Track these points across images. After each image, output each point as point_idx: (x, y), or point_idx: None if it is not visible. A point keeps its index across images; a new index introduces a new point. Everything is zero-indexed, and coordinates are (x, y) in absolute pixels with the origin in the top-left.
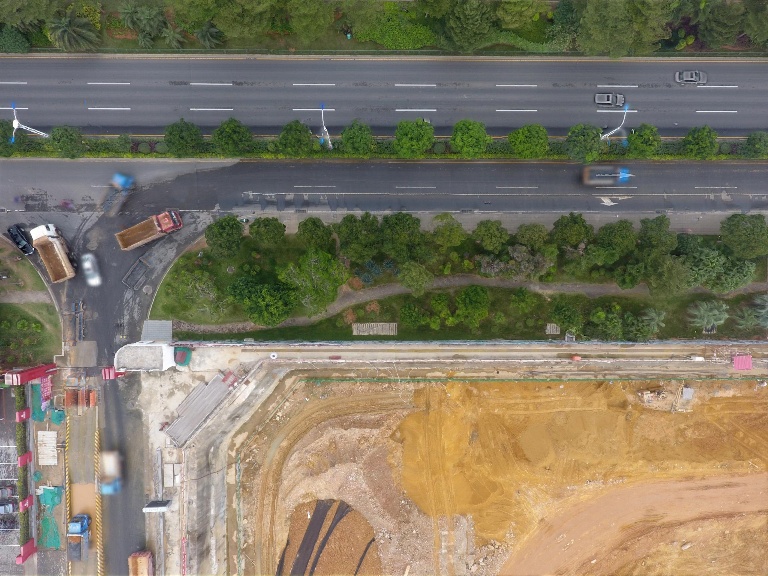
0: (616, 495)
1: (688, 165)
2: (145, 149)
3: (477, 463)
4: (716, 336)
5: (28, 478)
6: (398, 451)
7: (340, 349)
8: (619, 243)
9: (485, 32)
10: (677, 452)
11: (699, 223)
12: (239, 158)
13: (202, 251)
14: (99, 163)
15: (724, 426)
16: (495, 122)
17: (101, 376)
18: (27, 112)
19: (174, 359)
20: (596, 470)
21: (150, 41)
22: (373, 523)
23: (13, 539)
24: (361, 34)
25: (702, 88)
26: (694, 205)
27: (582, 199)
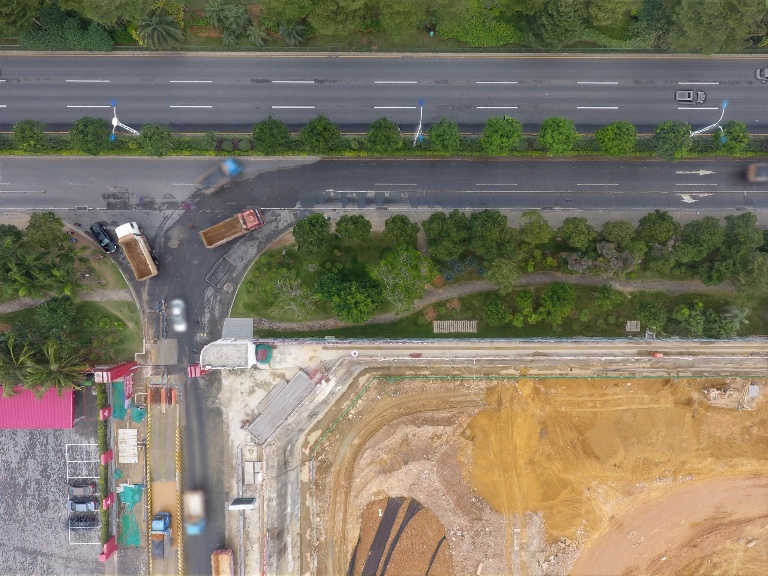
0: (685, 492)
1: None
2: (228, 147)
3: (547, 461)
4: None
5: (108, 476)
6: (469, 449)
7: (421, 347)
8: (707, 240)
9: (577, 29)
10: (744, 449)
11: None
12: (321, 156)
13: (283, 249)
14: (181, 161)
15: None
16: (576, 119)
17: (182, 374)
18: (109, 110)
19: (255, 357)
20: (665, 467)
21: (234, 39)
22: (444, 521)
23: (93, 537)
24: (444, 31)
25: None
26: None
27: (662, 196)
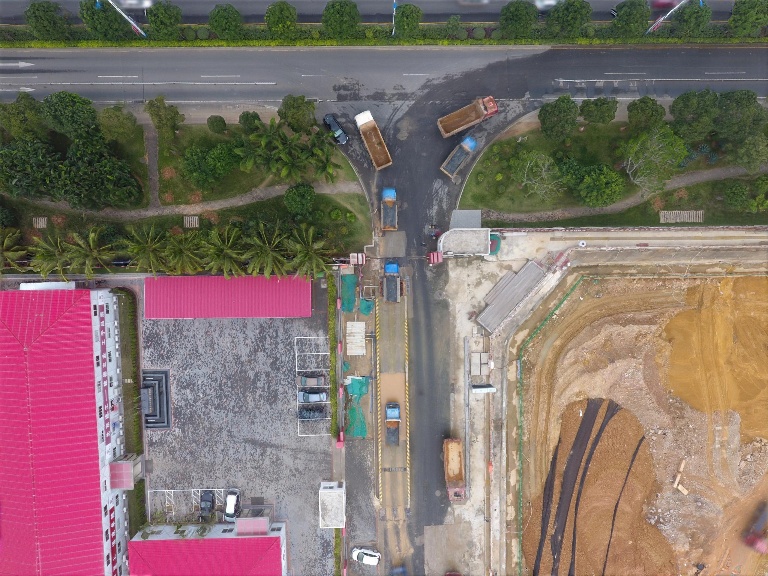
0: None
1: None
2: (464, 34)
3: (744, 361)
4: None
5: (336, 368)
6: (667, 350)
7: (647, 237)
8: None
9: None
10: None
11: None
12: (551, 45)
13: (513, 139)
14: (411, 51)
15: None
16: None
17: (410, 266)
18: None
19: None
20: None
21: None
22: (644, 420)
23: (321, 428)
24: None
25: None
26: None
27: None
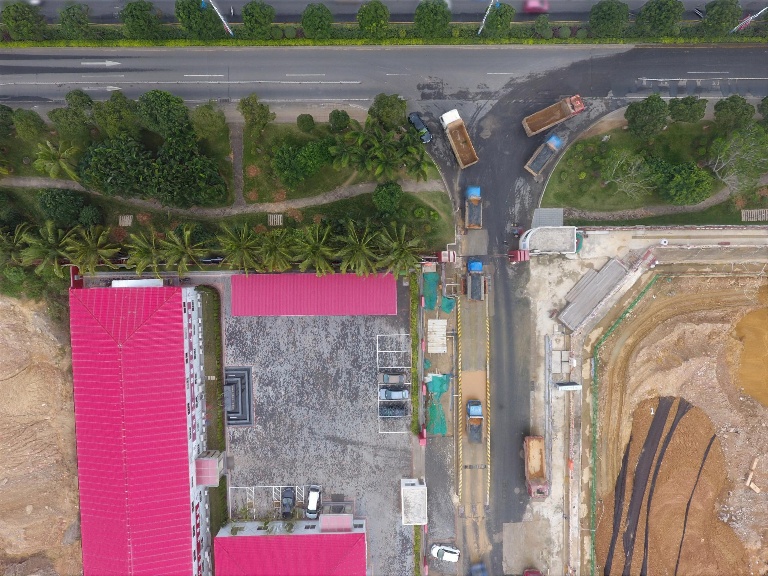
0: None
1: None
2: (549, 33)
3: None
4: None
5: (417, 366)
6: (738, 348)
7: (729, 235)
8: None
9: None
10: None
11: None
12: (635, 44)
13: (596, 138)
14: (495, 50)
15: None
16: None
17: (491, 264)
18: None
19: None
20: None
21: None
22: (715, 419)
23: (402, 426)
24: None
25: None
26: None
27: None
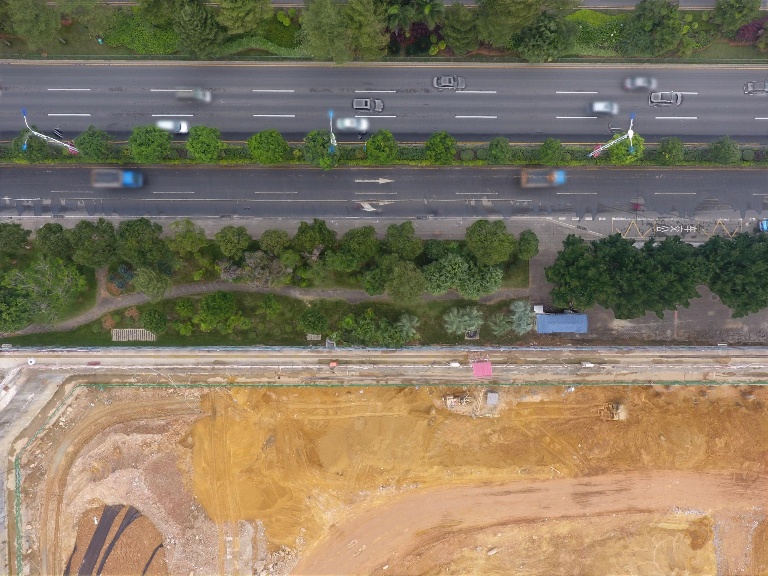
0: (410, 501)
1: (448, 171)
2: None
3: (267, 468)
4: (479, 342)
5: None
6: (187, 456)
7: (99, 355)
8: (357, 249)
9: (210, 38)
10: (478, 457)
11: (460, 229)
12: None
13: None
14: None
15: (532, 431)
16: (253, 127)
17: None
18: None
19: None
20: (390, 475)
21: None
22: (161, 529)
23: None
24: (111, 39)
25: (461, 93)
26: (455, 211)
27: (342, 205)
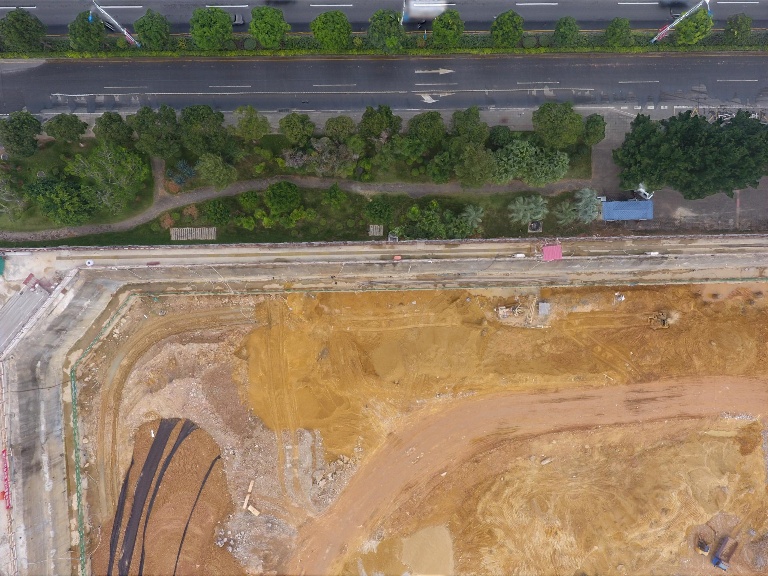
0: (466, 408)
1: (509, 60)
2: None
3: (324, 378)
4: (542, 235)
5: None
6: (243, 368)
7: (158, 255)
8: (424, 133)
9: None
10: (531, 366)
11: (521, 119)
12: (44, 58)
13: (10, 156)
14: None
15: (583, 341)
16: (309, 17)
17: None
18: None
19: None
20: (446, 383)
21: None
22: (218, 440)
23: None
24: None
25: None
26: (516, 101)
27: (402, 96)
